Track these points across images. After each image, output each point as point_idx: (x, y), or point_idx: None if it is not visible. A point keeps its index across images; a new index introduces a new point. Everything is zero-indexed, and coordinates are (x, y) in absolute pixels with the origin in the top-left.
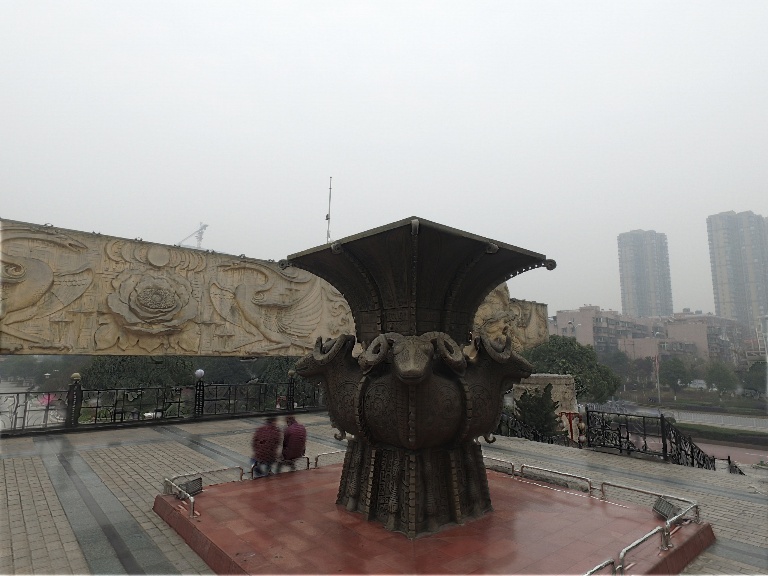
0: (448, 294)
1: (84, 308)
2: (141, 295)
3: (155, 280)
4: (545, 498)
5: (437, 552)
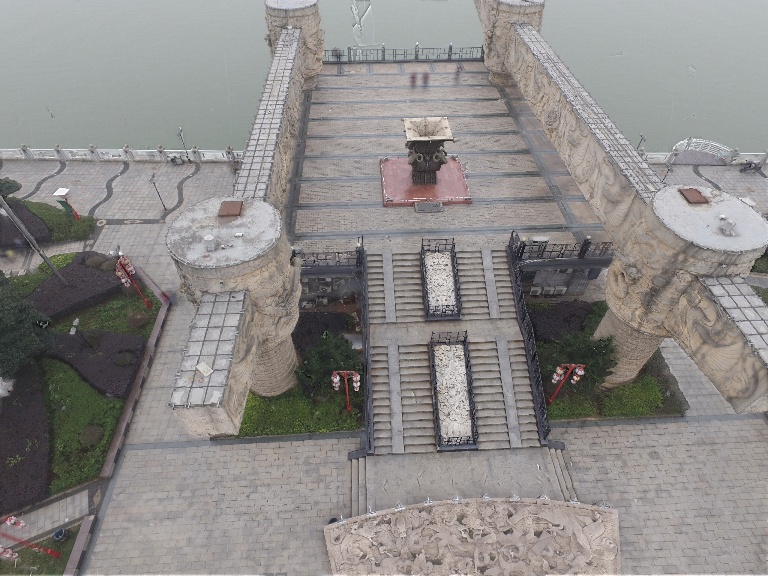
0: None
1: None
2: None
3: None
4: None
5: None
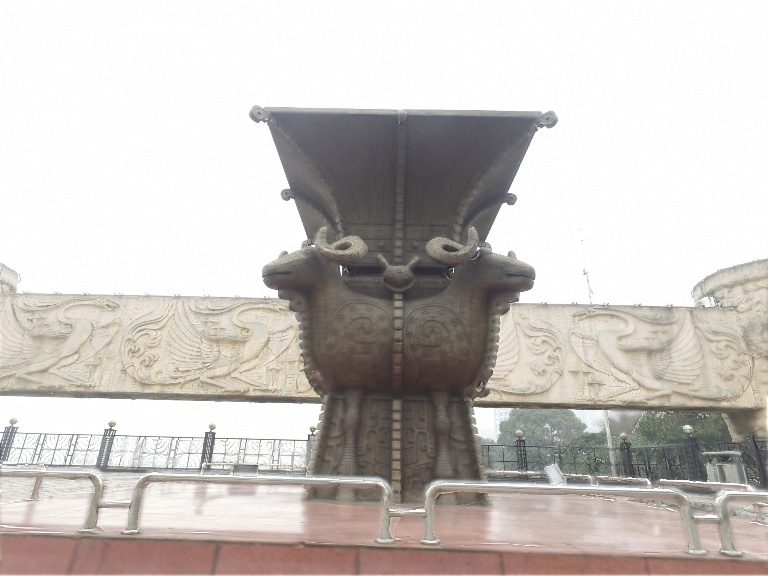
0: (395, 202)
1: (289, 358)
2: None
3: None
4: None
5: (285, 504)
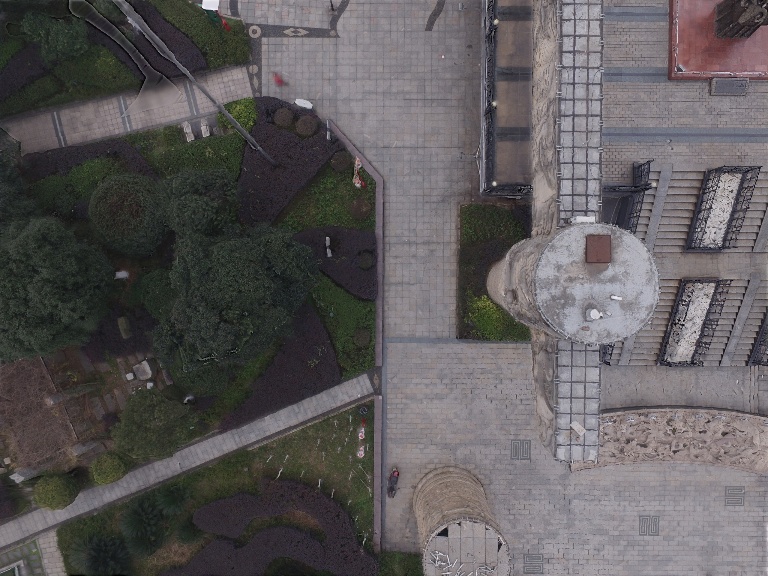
0: None
1: None
2: None
3: None
4: (712, 60)
5: (707, 3)
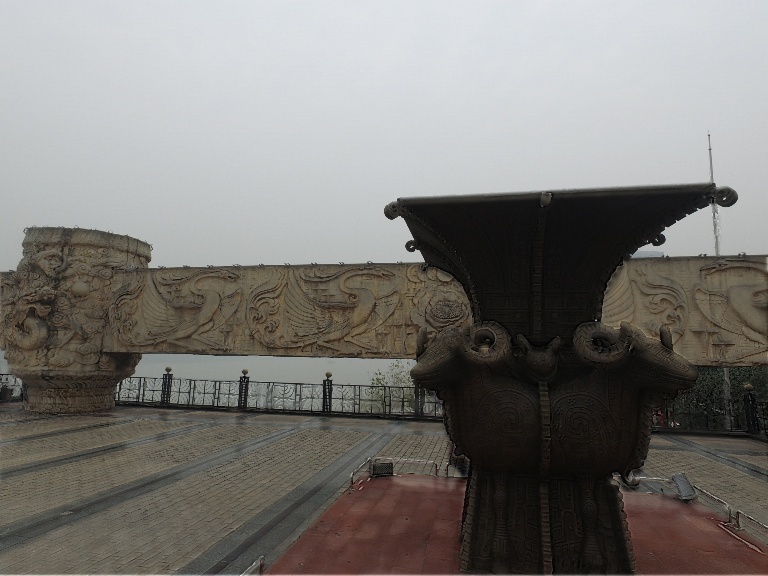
0: (532, 271)
1: (396, 322)
2: (434, 308)
3: (445, 294)
4: None
5: None
